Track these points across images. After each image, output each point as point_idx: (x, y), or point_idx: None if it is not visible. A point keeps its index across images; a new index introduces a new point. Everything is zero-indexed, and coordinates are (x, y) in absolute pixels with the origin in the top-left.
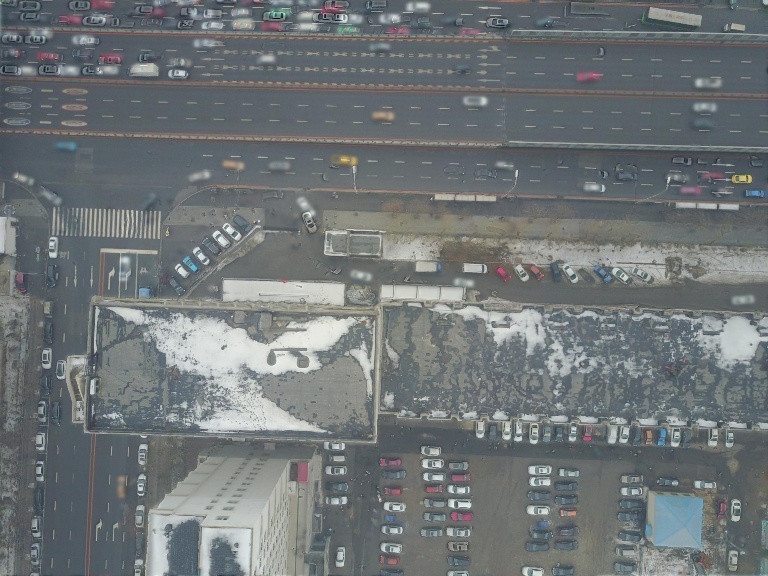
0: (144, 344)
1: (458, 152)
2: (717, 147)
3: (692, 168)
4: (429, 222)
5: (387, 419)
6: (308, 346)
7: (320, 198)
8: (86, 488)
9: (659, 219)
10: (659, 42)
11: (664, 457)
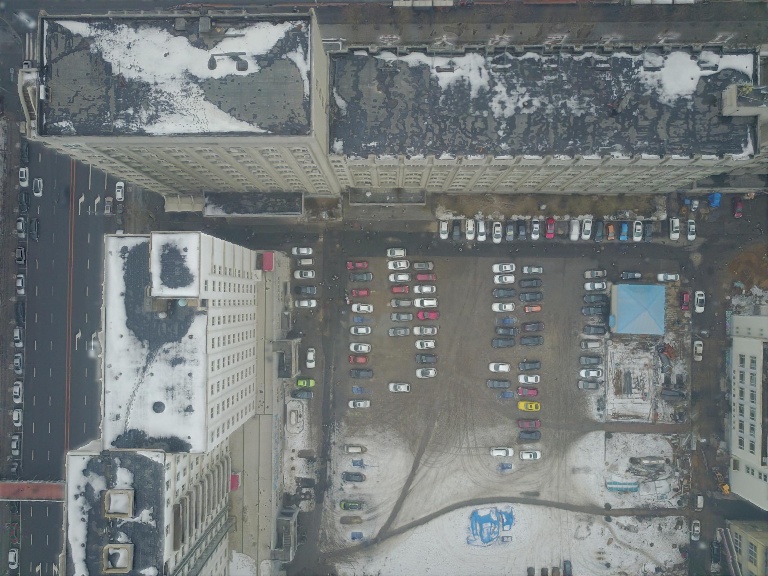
0: (91, 55)
1: None
2: None
3: None
4: (389, 32)
5: (353, 225)
6: (246, 50)
7: None
8: (65, 300)
9: (616, 19)
10: None
11: (627, 253)
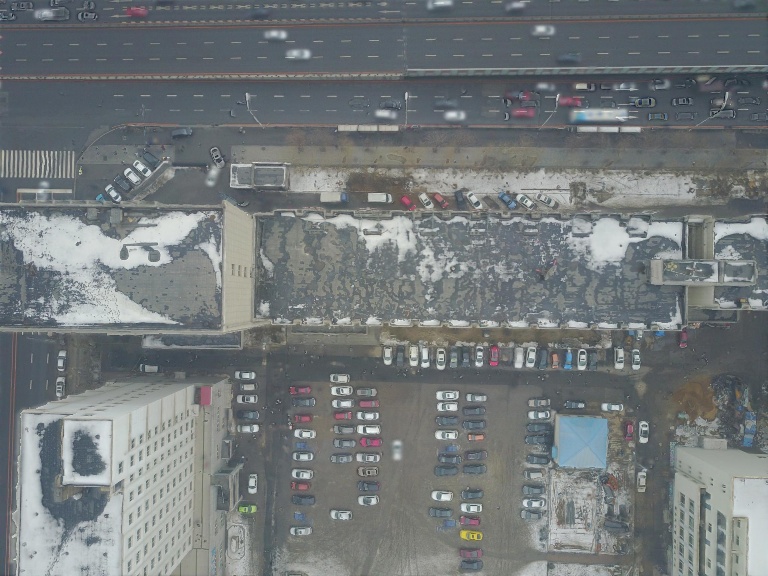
0: (2, 242)
1: (362, 85)
2: (613, 68)
3: (595, 94)
4: (335, 154)
5: (297, 348)
6: (159, 241)
7: (228, 134)
8: (7, 421)
9: (562, 145)
10: None
11: (572, 381)
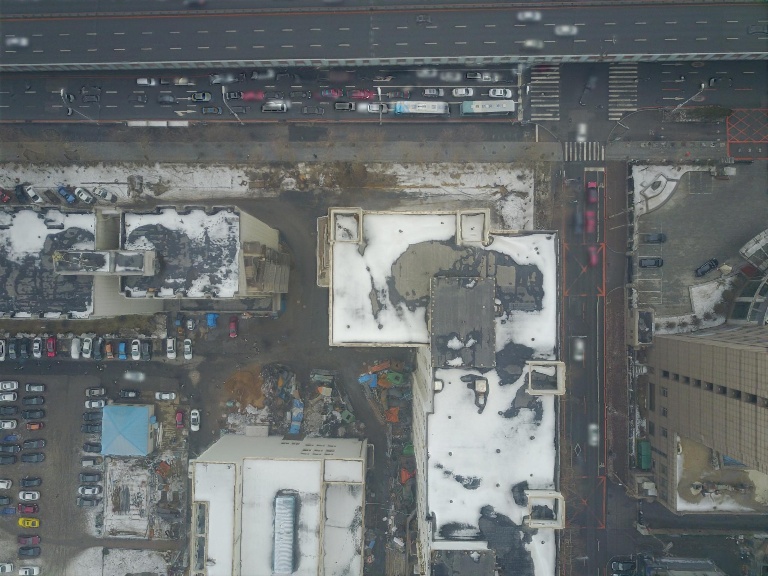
0: None
1: None
2: (145, 63)
3: (155, 88)
4: None
5: None
6: None
7: None
8: None
9: None
10: None
11: (130, 371)
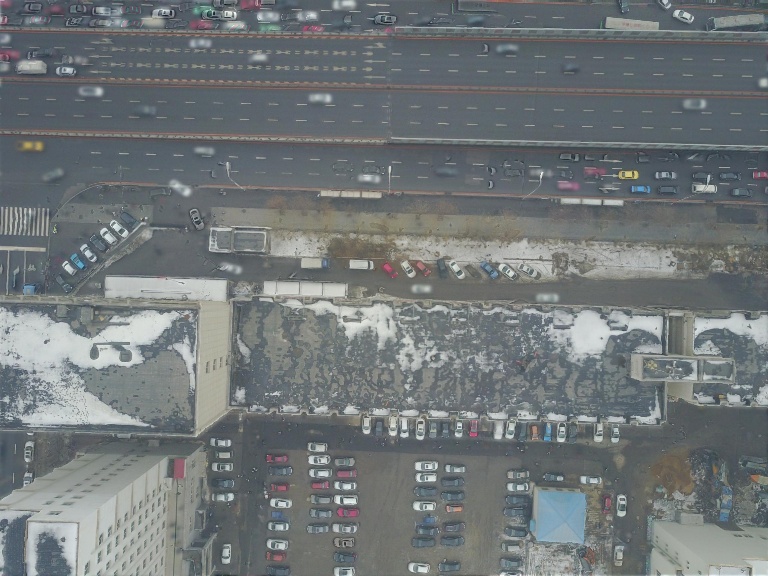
0: None
1: (346, 149)
2: (597, 143)
3: (579, 164)
4: (317, 219)
5: (274, 416)
6: (131, 340)
7: (208, 195)
8: None
9: (546, 215)
10: (543, 38)
11: (551, 453)
